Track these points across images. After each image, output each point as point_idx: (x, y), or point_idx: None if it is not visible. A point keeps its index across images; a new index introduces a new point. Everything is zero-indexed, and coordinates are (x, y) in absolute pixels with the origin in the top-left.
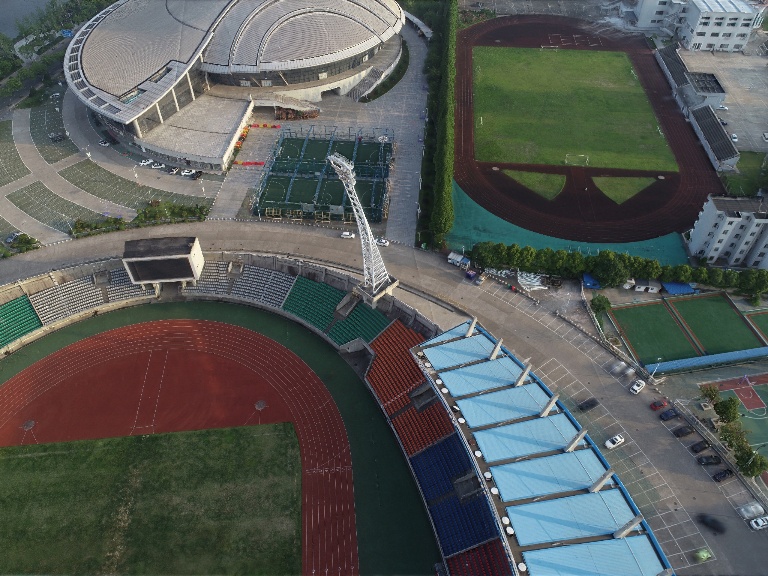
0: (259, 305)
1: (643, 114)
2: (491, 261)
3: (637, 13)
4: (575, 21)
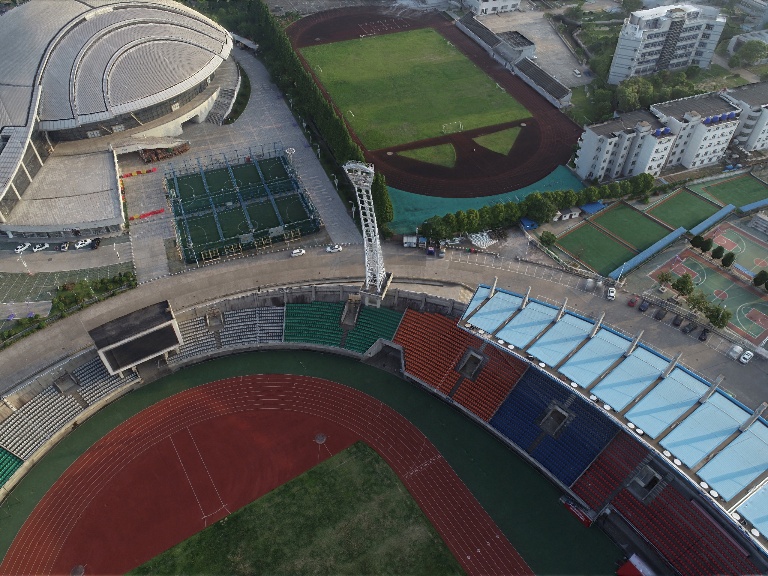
0: (254, 348)
1: (478, 76)
2: (445, 232)
3: None
4: (374, 8)
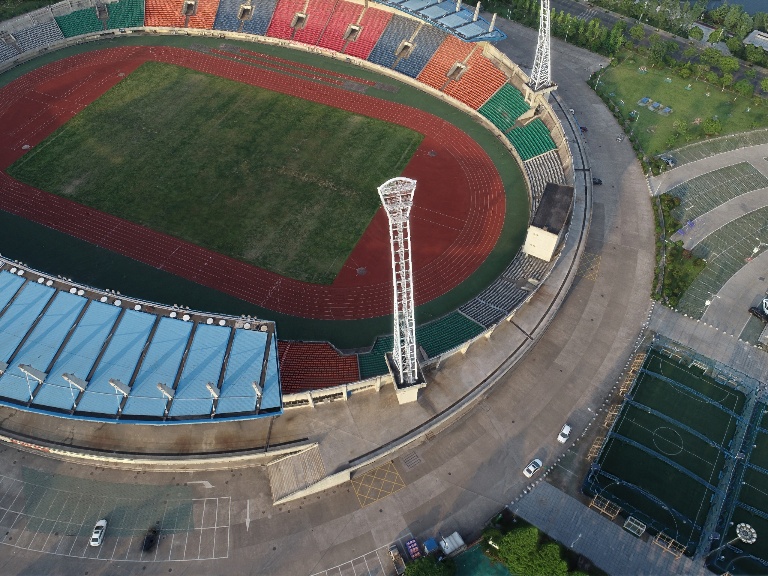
0: None
1: None
2: None
3: None
4: None
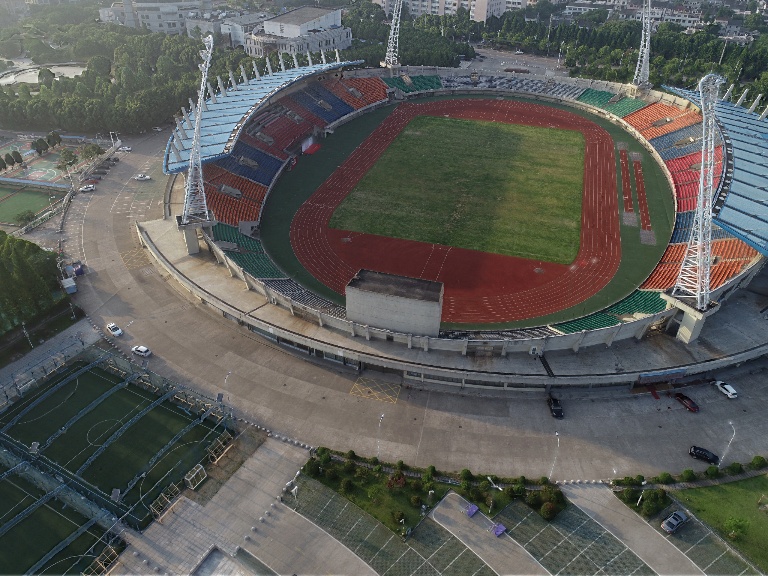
0: None
1: None
2: None
3: None
4: None
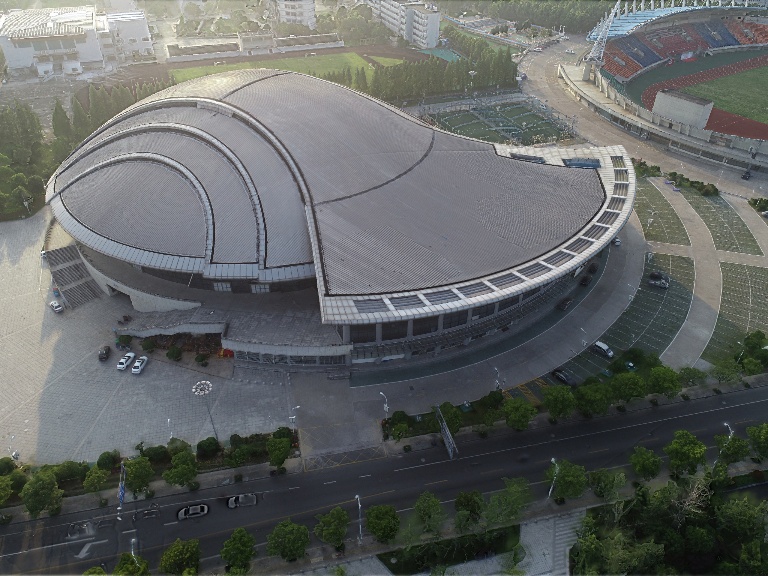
0: None
1: (284, 61)
2: None
3: (91, 59)
4: None
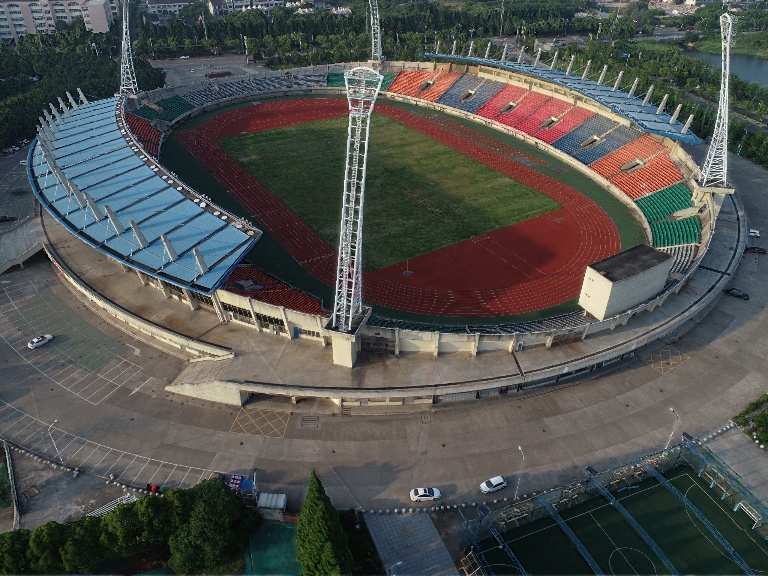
0: None
1: None
2: None
3: None
4: None
